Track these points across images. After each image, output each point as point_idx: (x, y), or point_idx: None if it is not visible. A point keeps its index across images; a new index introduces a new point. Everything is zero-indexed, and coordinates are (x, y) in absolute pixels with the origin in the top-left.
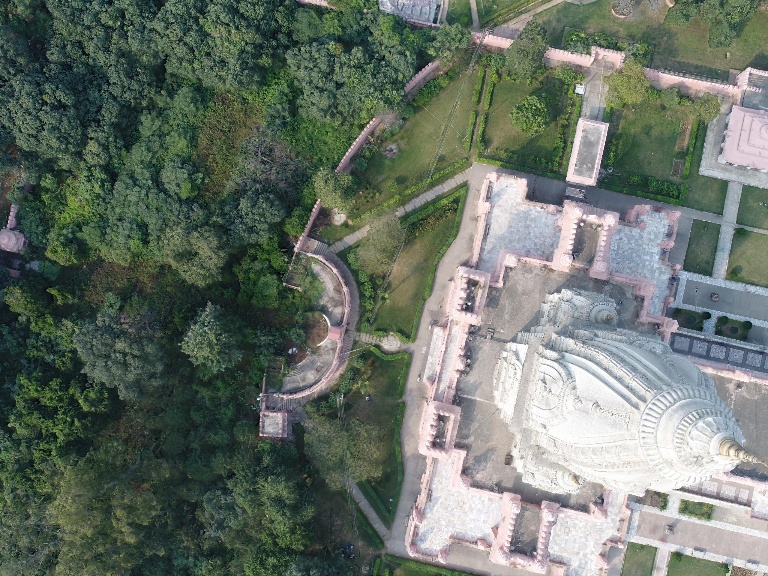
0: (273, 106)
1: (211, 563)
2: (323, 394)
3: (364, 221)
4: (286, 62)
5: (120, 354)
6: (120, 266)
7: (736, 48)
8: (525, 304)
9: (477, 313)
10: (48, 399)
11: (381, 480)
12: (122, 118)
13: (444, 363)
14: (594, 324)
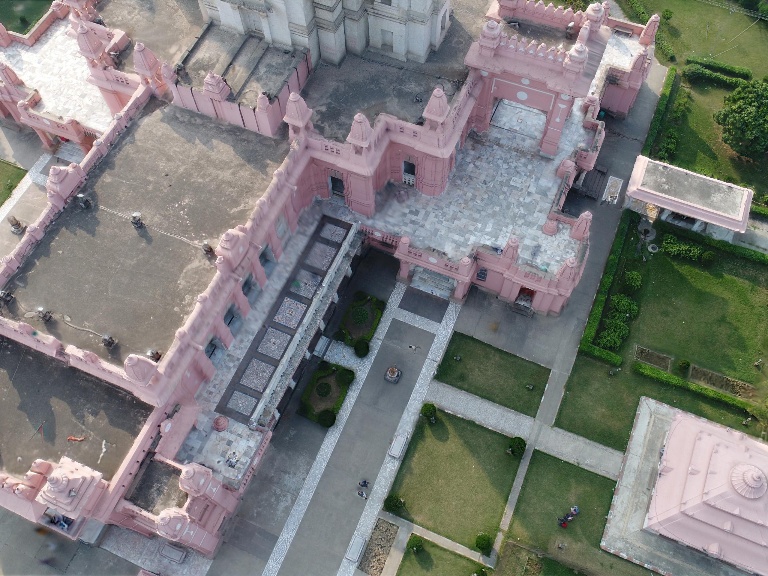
0: None
1: None
2: None
3: None
4: None
5: None
6: None
7: None
8: None
9: None
10: None
11: None
12: None
13: None
14: None
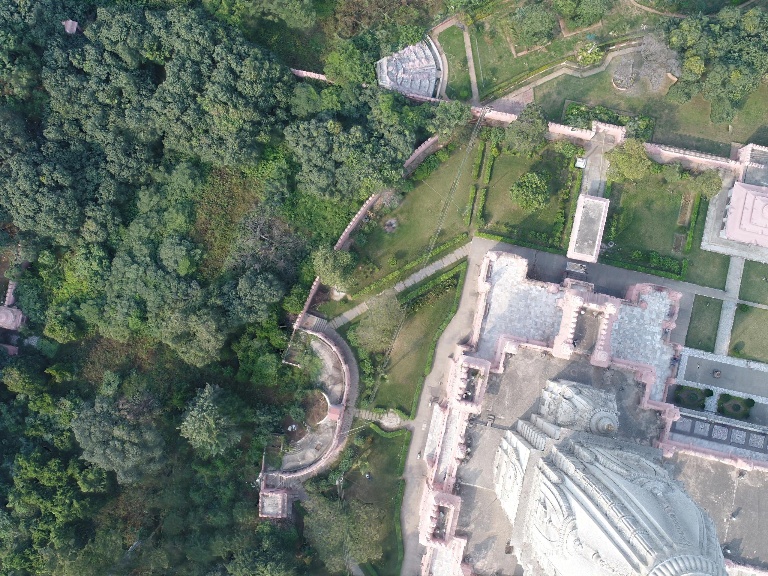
0: (272, 181)
1: None
2: (323, 471)
3: (363, 296)
4: (285, 136)
5: (118, 442)
6: (118, 342)
7: (738, 121)
8: (525, 390)
9: (477, 402)
10: (47, 480)
11: (381, 559)
12: (120, 195)
13: (444, 444)
14: (595, 437)
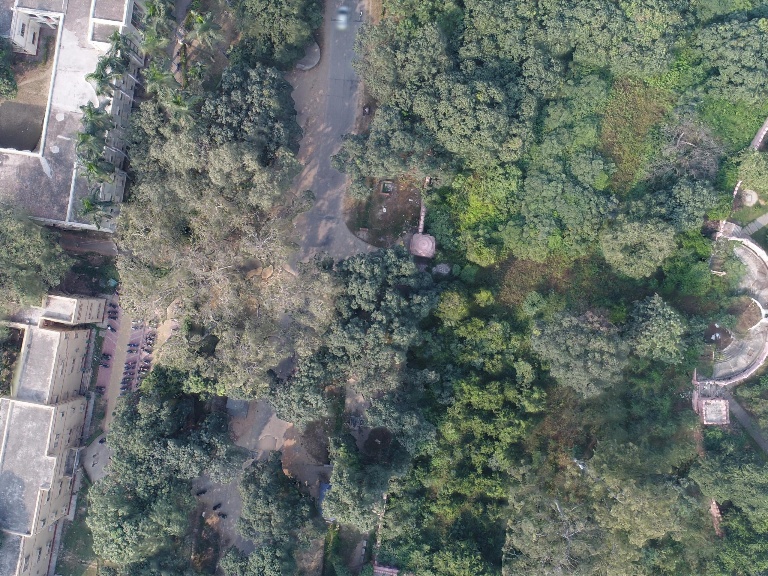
0: None
1: (664, 553)
2: (749, 378)
3: None
4: None
5: (598, 353)
6: (534, 263)
7: None
8: None
9: None
10: (489, 403)
11: None
12: (534, 112)
13: None
14: None
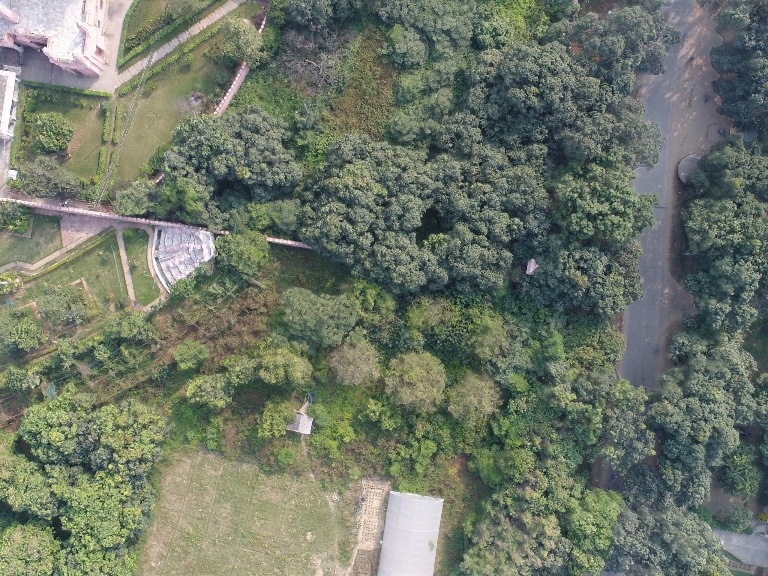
0: None
1: None
2: None
3: None
4: None
5: None
6: None
7: None
8: None
9: None
10: None
11: None
12: None
13: None
14: None
